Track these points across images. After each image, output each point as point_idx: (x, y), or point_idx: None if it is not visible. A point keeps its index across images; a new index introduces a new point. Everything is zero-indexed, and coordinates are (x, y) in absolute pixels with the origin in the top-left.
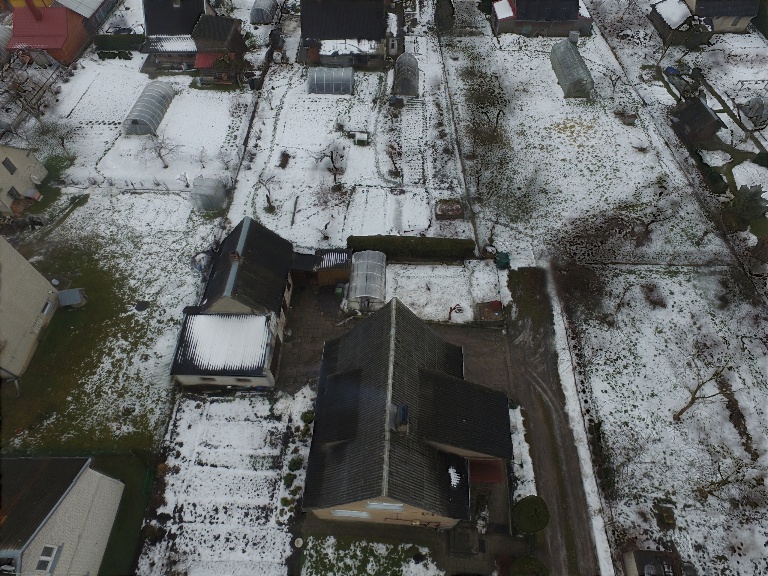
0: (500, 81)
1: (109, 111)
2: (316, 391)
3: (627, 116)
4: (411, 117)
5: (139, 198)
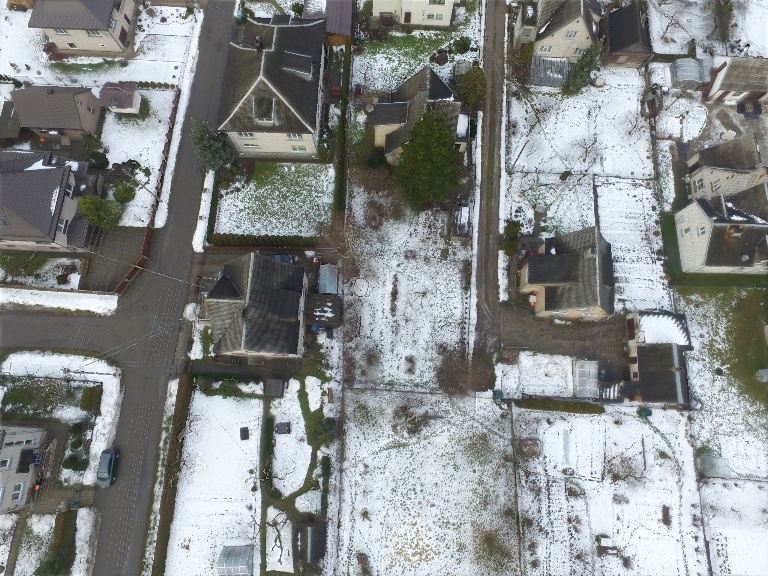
0: None
1: None
2: None
3: None
4: None
5: (767, 471)
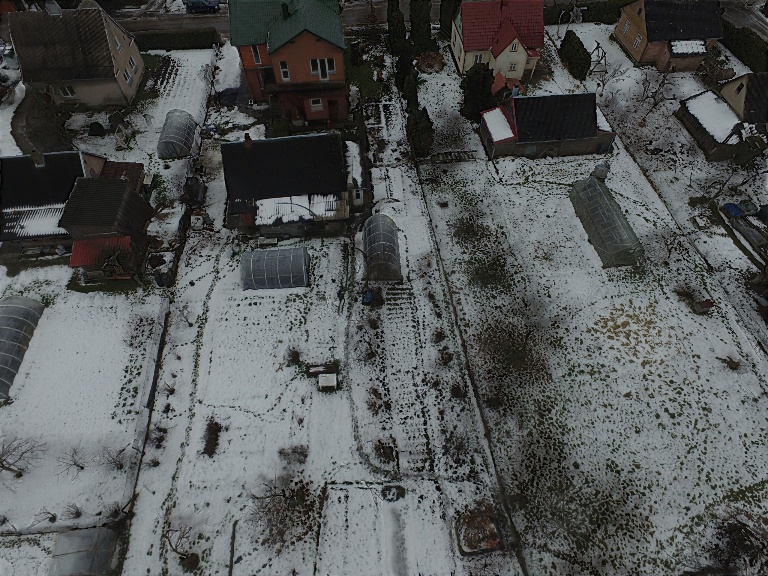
0: (510, 242)
1: None
2: None
3: (699, 304)
4: (396, 325)
5: None
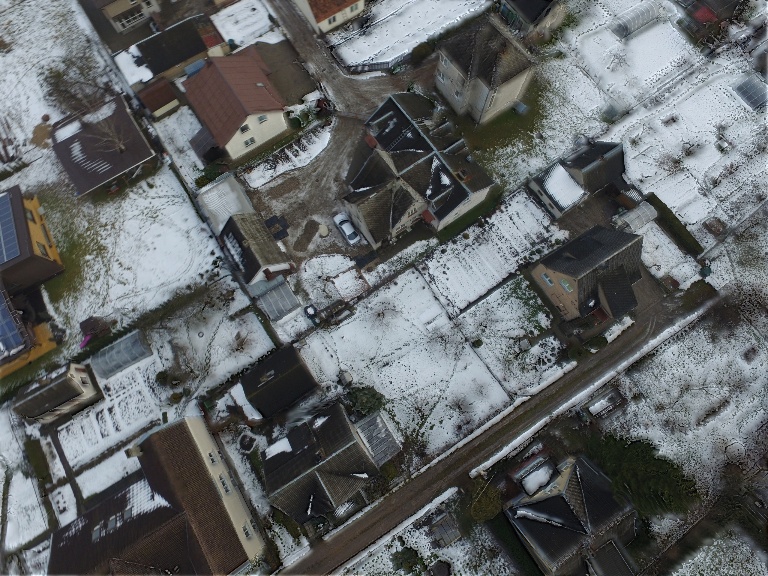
0: None
1: (612, 0)
2: (570, 237)
3: None
4: (767, 157)
5: (581, 77)
